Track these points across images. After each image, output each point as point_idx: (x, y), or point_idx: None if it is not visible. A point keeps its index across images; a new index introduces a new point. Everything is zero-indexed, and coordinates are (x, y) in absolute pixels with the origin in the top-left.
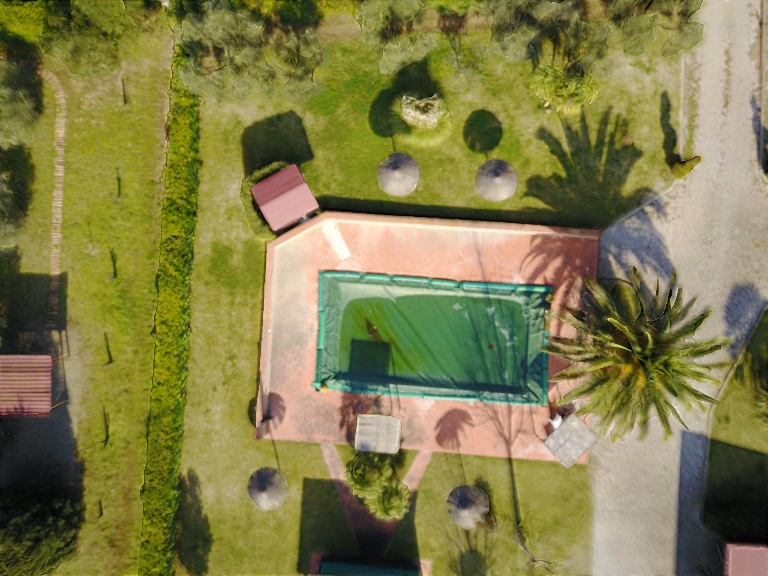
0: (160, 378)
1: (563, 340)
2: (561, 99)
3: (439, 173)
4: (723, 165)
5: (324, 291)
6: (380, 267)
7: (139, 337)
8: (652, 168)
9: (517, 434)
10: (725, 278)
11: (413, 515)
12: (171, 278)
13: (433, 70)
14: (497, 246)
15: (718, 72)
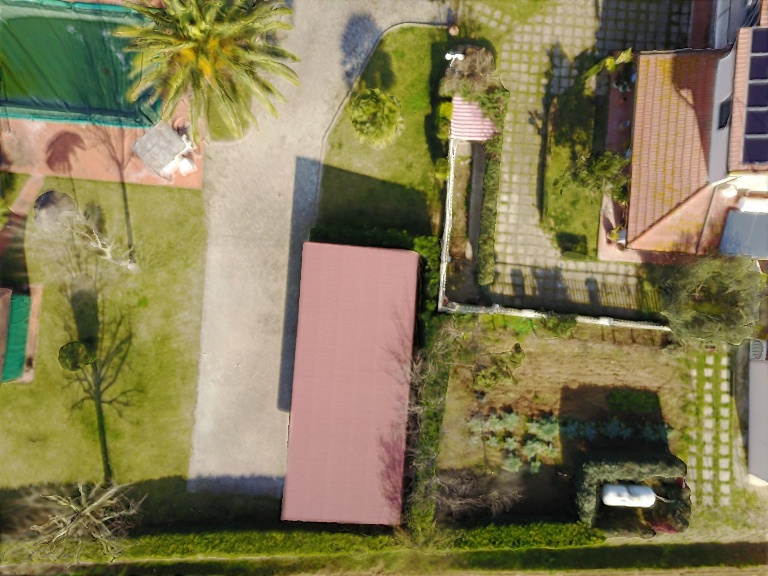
0: None
1: None
2: None
3: None
4: None
5: None
6: None
7: None
8: None
9: (130, 158)
10: (343, 8)
11: (22, 239)
12: None
13: None
14: None
15: None
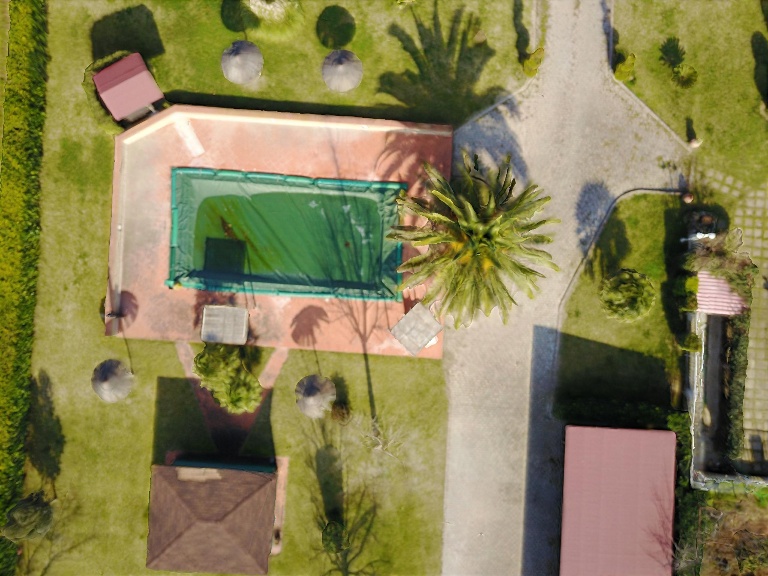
0: (3, 274)
1: (406, 227)
2: None
3: (293, 69)
4: (575, 65)
5: (177, 188)
6: (234, 164)
7: None
8: (505, 67)
9: (372, 330)
10: (576, 176)
11: (268, 412)
12: (14, 172)
13: None
14: (352, 143)
15: None
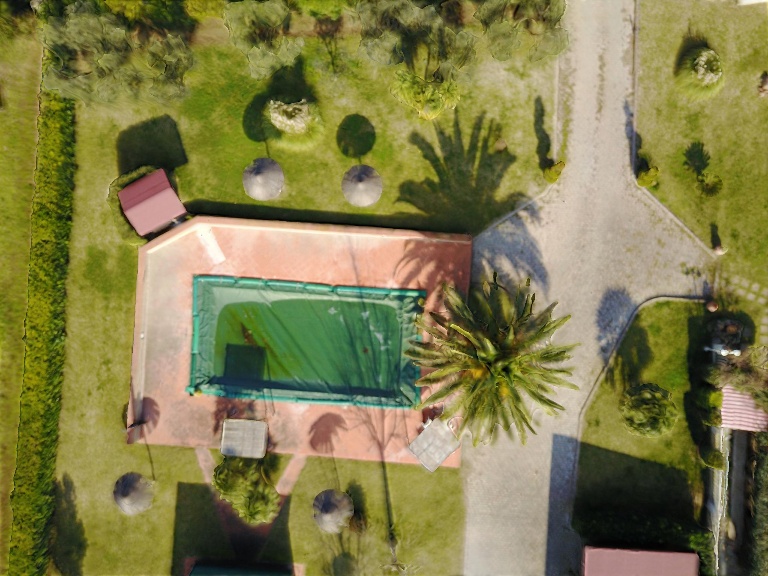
0: (30, 383)
1: (425, 345)
2: (420, 105)
3: (312, 177)
4: (596, 170)
5: (199, 295)
6: (255, 271)
7: (16, 341)
8: (525, 173)
9: (390, 437)
10: (597, 282)
11: (287, 518)
12: (41, 283)
13: (308, 74)
14: (371, 250)
15: (592, 77)
